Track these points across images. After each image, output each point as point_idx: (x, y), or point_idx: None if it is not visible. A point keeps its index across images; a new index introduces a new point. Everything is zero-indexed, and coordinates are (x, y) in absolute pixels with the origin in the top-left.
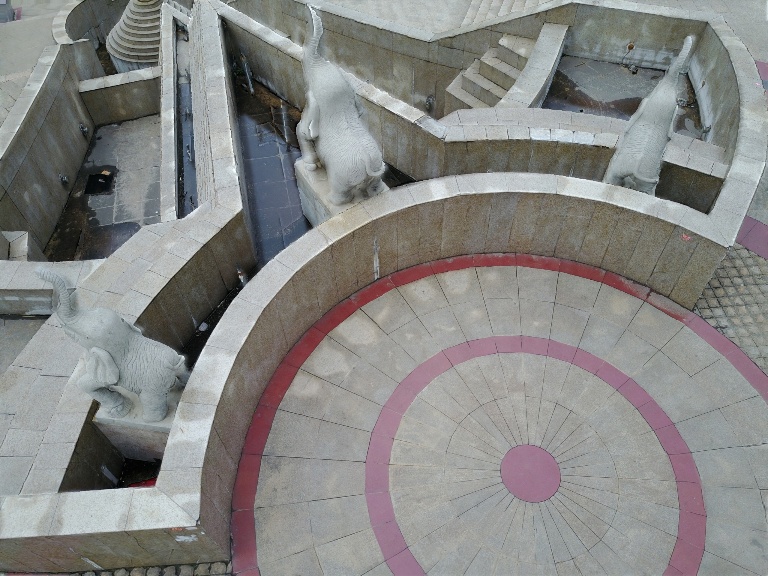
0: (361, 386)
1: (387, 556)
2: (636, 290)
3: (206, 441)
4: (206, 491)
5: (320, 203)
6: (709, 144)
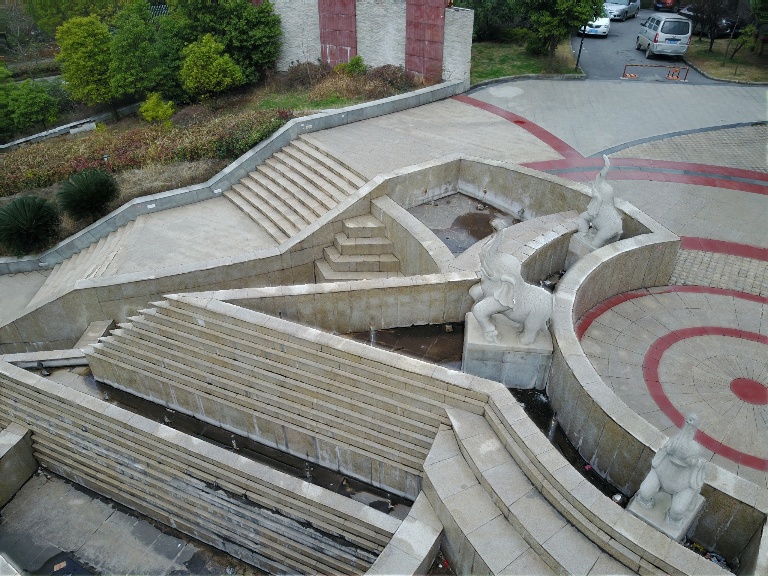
0: None
1: None
2: (642, 293)
3: (737, 476)
4: None
5: (518, 351)
6: (567, 212)
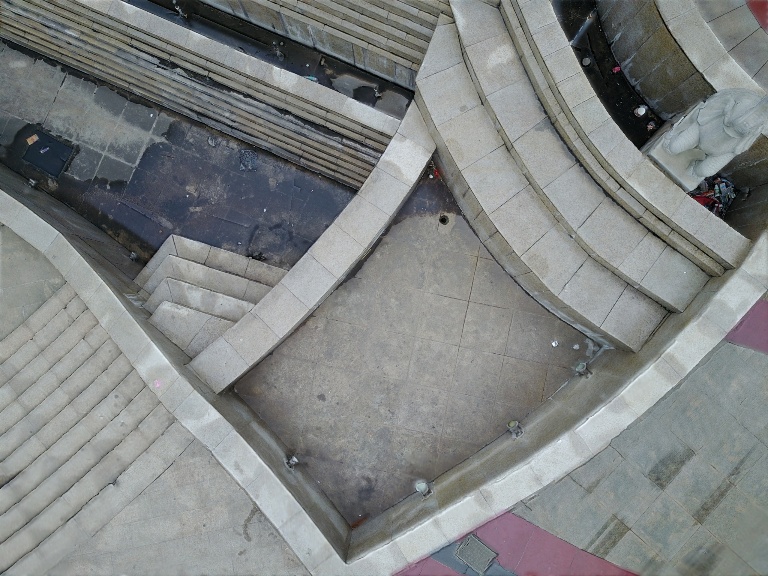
0: (716, 8)
1: None
2: None
3: None
4: None
5: None
6: None
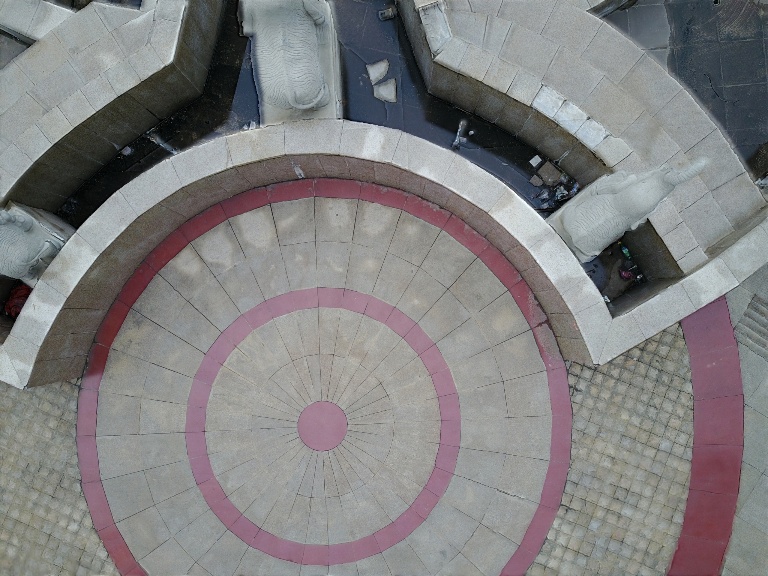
0: (233, 287)
1: (188, 430)
2: (533, 314)
3: (49, 326)
4: (46, 356)
5: None
6: (754, 189)
